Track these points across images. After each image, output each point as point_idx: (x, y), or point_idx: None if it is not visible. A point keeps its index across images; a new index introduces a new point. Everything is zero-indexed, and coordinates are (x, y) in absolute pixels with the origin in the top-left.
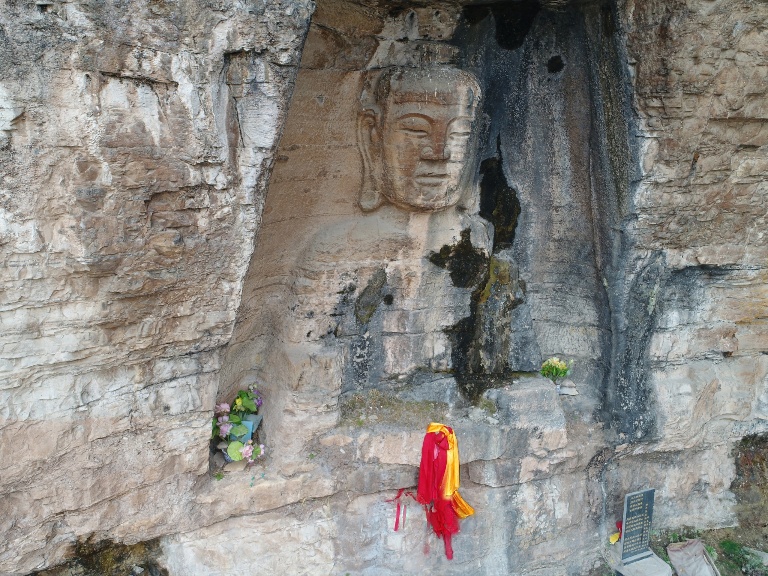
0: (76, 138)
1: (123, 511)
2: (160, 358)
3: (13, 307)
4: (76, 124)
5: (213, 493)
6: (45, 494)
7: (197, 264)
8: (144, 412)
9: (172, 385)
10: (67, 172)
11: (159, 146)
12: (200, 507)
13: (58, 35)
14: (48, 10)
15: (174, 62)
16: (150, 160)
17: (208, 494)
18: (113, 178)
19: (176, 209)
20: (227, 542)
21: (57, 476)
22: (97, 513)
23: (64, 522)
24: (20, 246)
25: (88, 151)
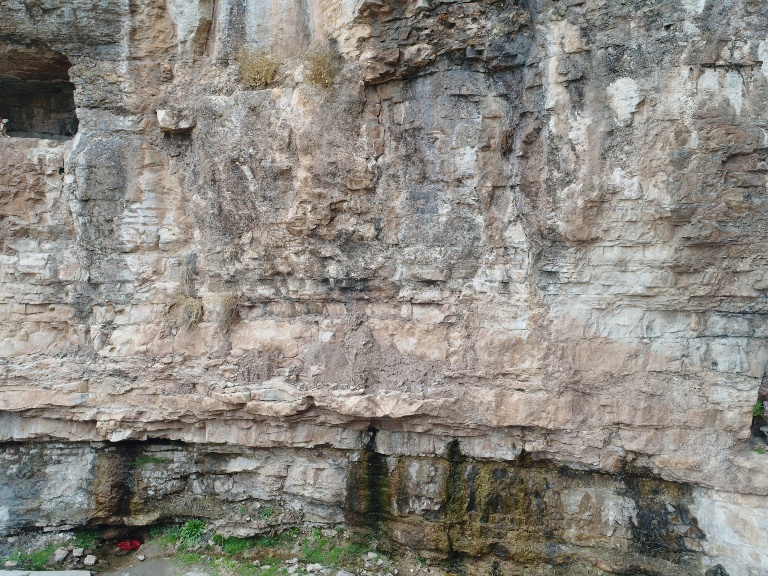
0: (677, 113)
1: (665, 444)
2: (715, 312)
3: (613, 244)
4: (678, 104)
5: (752, 461)
6: (609, 402)
7: (761, 221)
8: (694, 361)
9: (722, 342)
10: (666, 140)
11: (740, 116)
12: (737, 470)
13: (675, 44)
14: (671, 28)
15: (761, 46)
16: (731, 126)
17: (747, 460)
18: (699, 143)
19: (748, 170)
20: (762, 518)
21: (619, 391)
22: (644, 435)
23: (618, 434)
24: (627, 194)
25: (683, 123)
